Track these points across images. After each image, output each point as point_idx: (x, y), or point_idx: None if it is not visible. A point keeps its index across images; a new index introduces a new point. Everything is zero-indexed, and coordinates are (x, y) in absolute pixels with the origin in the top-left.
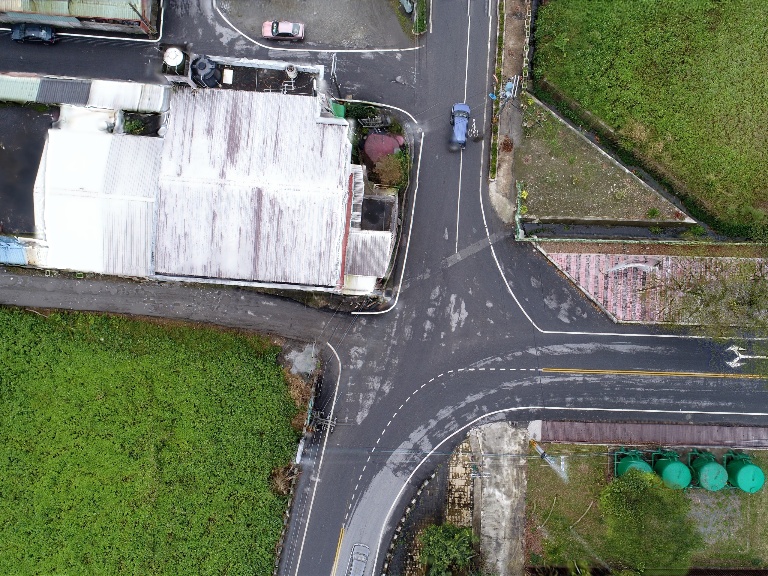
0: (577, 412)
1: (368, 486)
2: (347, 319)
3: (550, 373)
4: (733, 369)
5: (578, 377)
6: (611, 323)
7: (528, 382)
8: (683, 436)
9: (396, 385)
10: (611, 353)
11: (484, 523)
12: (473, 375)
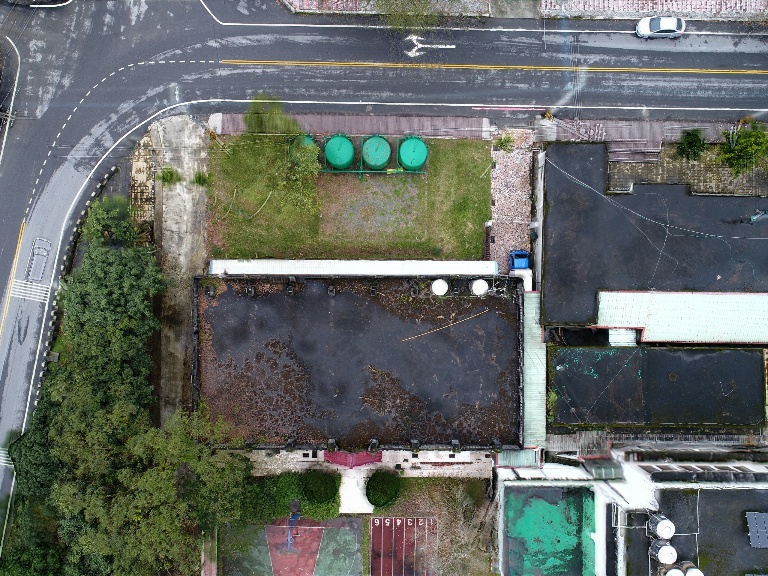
0: (257, 104)
1: (49, 180)
2: (25, 12)
3: (229, 65)
4: (412, 59)
5: (258, 69)
6: (290, 14)
7: (208, 74)
8: (362, 126)
9: (76, 79)
10: (290, 44)
11: (166, 217)
12: (153, 68)
